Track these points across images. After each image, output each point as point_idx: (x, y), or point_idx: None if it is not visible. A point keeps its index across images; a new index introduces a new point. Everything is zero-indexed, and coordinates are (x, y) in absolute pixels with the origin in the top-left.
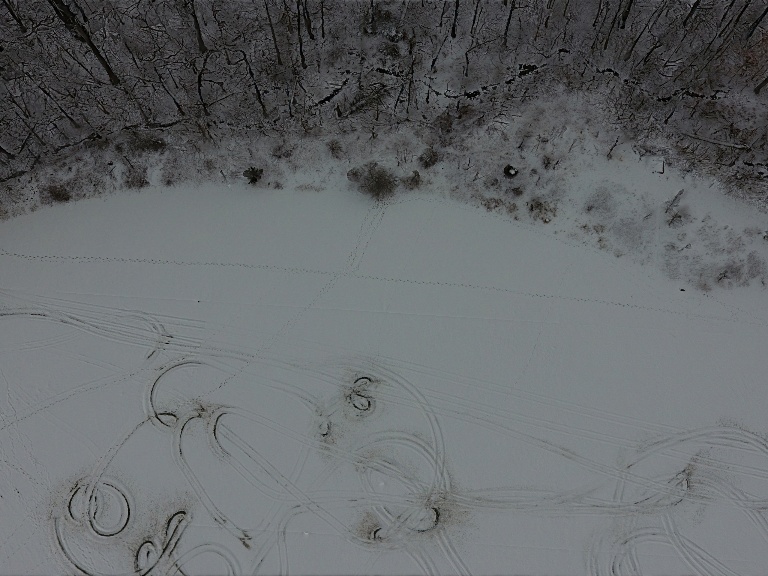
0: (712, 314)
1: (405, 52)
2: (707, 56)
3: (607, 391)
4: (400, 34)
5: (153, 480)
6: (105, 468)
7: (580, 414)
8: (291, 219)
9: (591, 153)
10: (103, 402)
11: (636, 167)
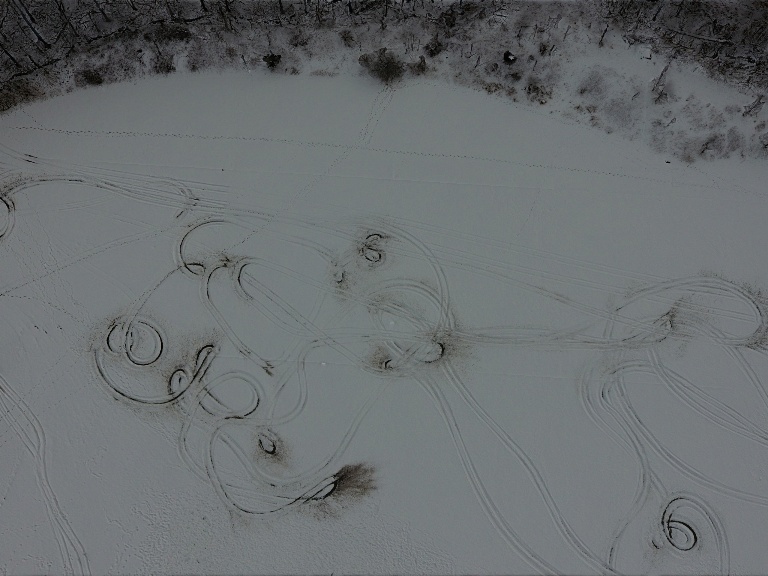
0: (695, 182)
1: None
2: None
3: (598, 246)
4: None
5: (183, 319)
6: (140, 309)
7: (573, 266)
8: (307, 100)
9: (584, 41)
10: (137, 254)
11: (626, 54)
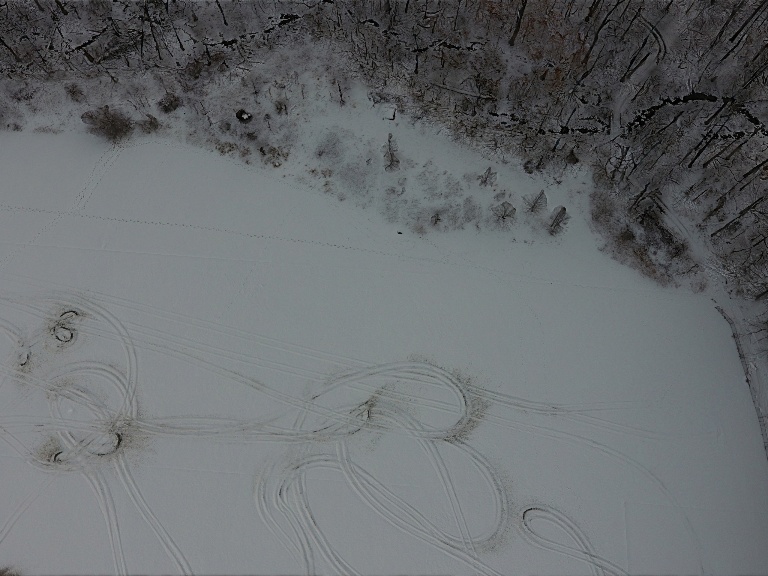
0: (424, 256)
1: (169, 0)
2: (468, 8)
3: (306, 327)
4: None
5: None
6: None
7: (276, 348)
8: (26, 160)
9: (325, 99)
10: None
11: (368, 113)
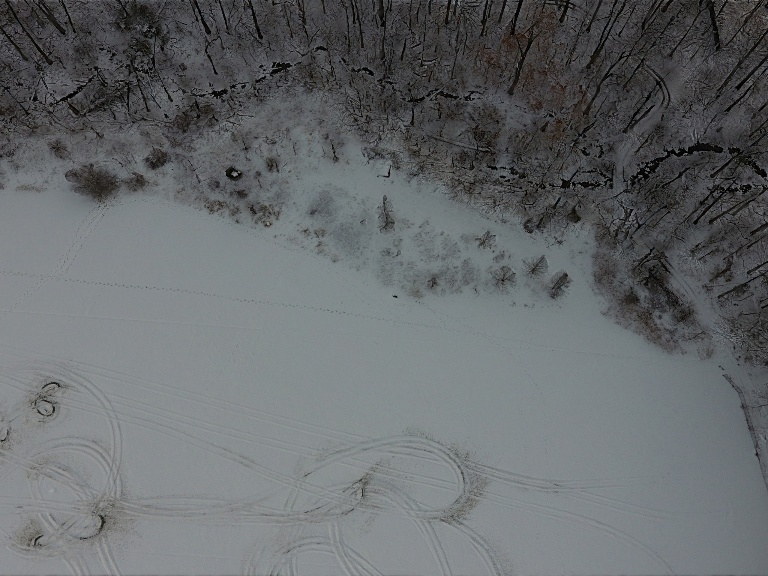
0: (420, 321)
1: (157, 48)
2: (466, 56)
3: (298, 399)
4: (153, 30)
5: None
6: None
7: (266, 422)
8: (8, 220)
9: (318, 156)
10: None
11: (362, 170)
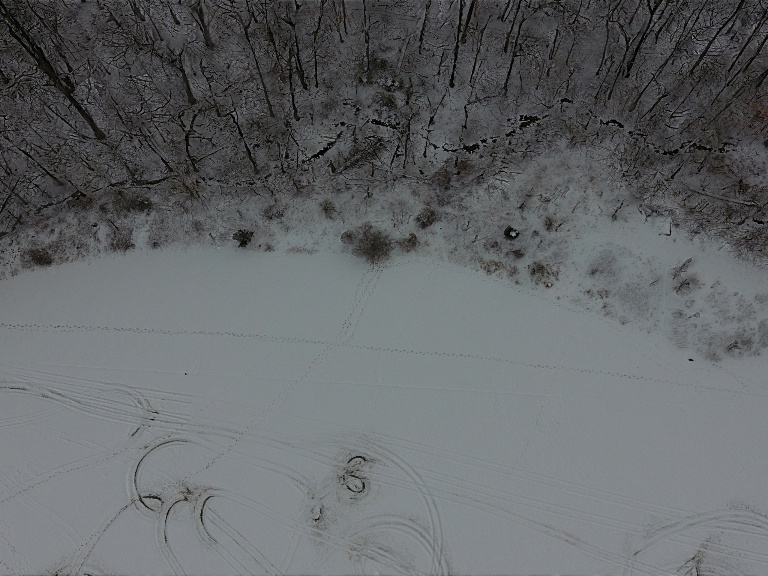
0: (722, 386)
1: (402, 102)
2: (715, 106)
3: (612, 471)
4: (396, 84)
5: (136, 570)
6: (86, 557)
7: (584, 496)
8: (283, 284)
9: (595, 214)
10: (85, 484)
11: (642, 228)
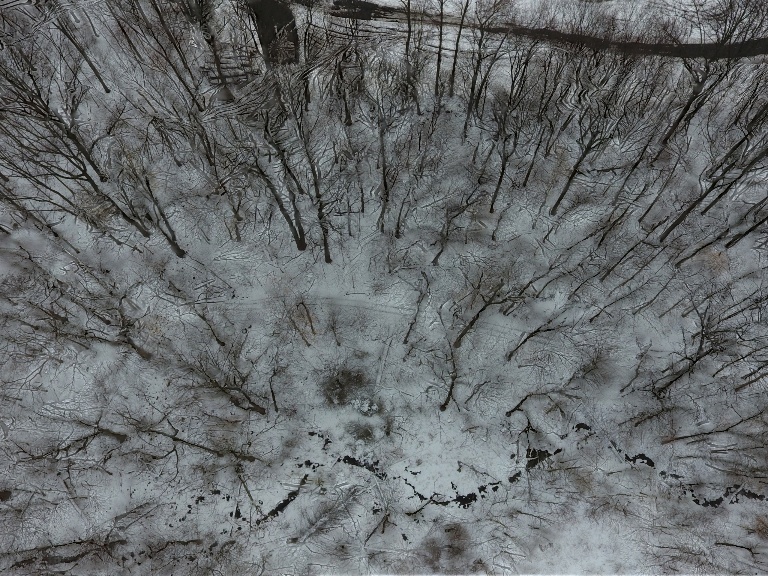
0: None
1: (381, 432)
2: (766, 437)
3: None
4: (375, 407)
5: None
6: None
7: None
8: None
9: None
10: None
11: None
